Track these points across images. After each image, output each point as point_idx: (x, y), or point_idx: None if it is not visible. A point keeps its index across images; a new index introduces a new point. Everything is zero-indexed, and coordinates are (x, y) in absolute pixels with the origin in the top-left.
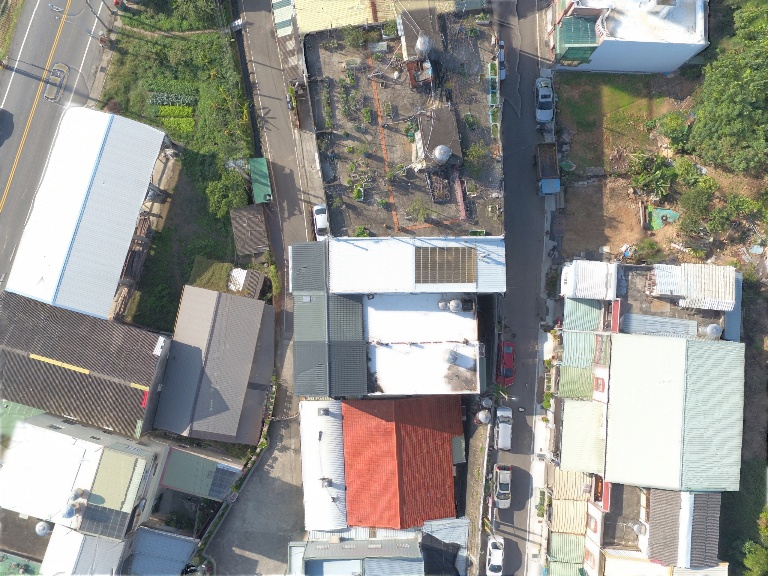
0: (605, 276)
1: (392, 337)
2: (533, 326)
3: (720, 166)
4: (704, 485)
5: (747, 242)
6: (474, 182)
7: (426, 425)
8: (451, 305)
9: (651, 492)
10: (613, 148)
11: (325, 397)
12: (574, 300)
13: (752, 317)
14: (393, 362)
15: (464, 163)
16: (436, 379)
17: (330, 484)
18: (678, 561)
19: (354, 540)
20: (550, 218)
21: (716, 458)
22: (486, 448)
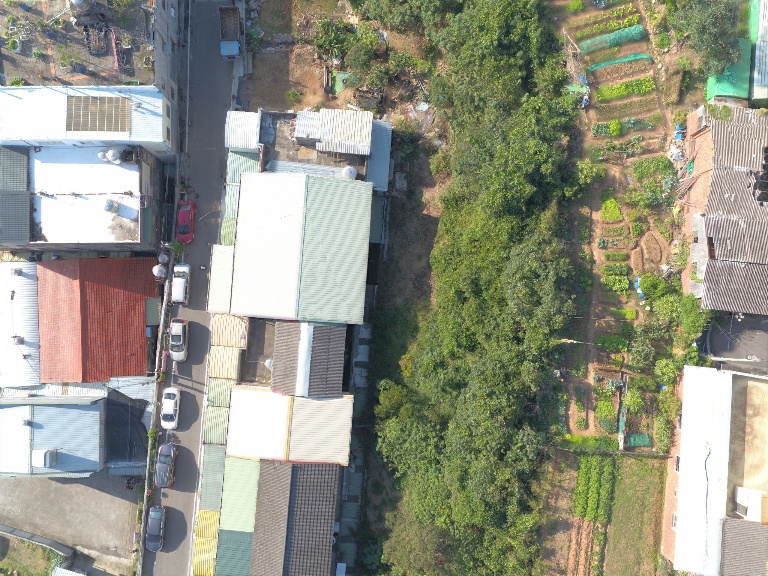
0: (256, 125)
1: (56, 188)
2: (217, 187)
3: (395, 28)
4: (322, 316)
5: (414, 99)
6: (122, 31)
7: (116, 285)
8: (108, 154)
9: (275, 325)
10: (301, 15)
11: (22, 260)
12: (238, 154)
13: (414, 171)
14: (58, 212)
15: (110, 12)
16: (101, 230)
17: (22, 342)
18: (296, 390)
19: (44, 396)
20: (237, 83)
21: (337, 291)
22: (163, 303)
